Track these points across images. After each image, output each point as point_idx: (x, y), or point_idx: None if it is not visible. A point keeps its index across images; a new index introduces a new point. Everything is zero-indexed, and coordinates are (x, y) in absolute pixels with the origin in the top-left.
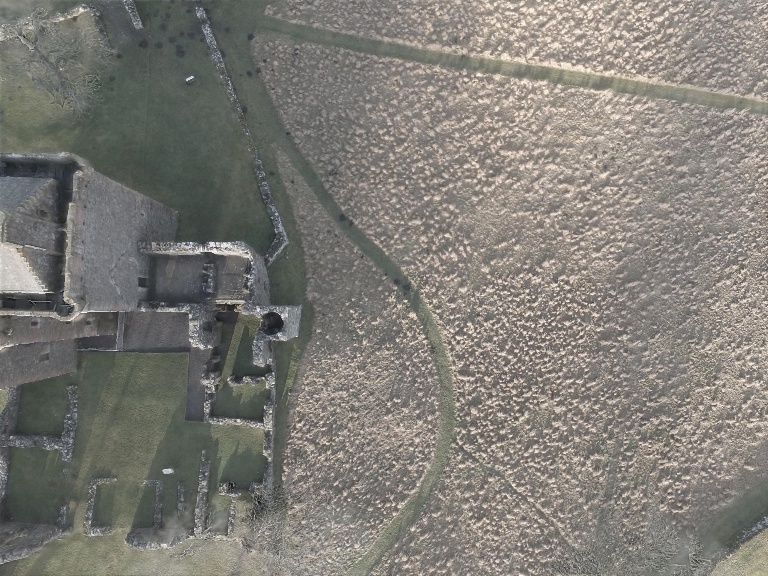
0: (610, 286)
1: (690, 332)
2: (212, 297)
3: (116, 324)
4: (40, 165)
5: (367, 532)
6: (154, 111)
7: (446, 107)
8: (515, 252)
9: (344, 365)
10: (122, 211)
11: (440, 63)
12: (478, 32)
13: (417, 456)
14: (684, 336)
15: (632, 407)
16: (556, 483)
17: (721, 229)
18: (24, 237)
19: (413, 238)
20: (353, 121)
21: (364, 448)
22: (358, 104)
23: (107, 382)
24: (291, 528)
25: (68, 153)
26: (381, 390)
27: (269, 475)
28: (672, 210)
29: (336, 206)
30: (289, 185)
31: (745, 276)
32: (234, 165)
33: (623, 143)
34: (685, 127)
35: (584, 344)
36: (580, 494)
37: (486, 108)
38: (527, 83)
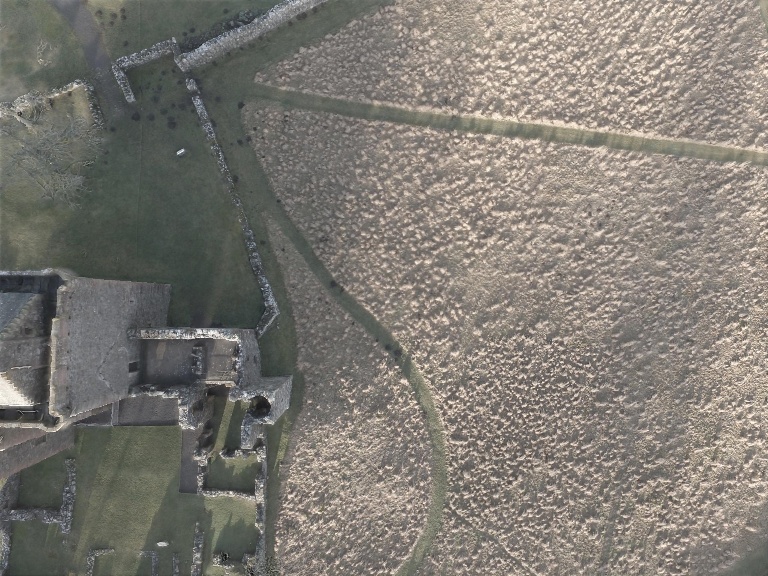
0: (605, 346)
1: (689, 392)
2: (201, 378)
3: None
4: (26, 278)
5: None
6: (147, 184)
7: (437, 169)
8: (508, 314)
9: (335, 434)
10: (110, 306)
11: (430, 125)
12: (468, 92)
13: (410, 522)
14: (682, 396)
15: (629, 469)
16: (551, 547)
17: (721, 285)
18: (7, 363)
19: (404, 303)
20: (343, 186)
21: (356, 515)
22: (348, 169)
23: (104, 455)
24: None
25: (51, 269)
26: (373, 457)
27: (261, 548)
28: (669, 267)
29: (327, 272)
30: (280, 253)
31: (746, 333)
32: (225, 236)
33: (618, 200)
34: (683, 182)
35: (579, 406)
36: (575, 558)
37: (477, 168)
38: (519, 142)
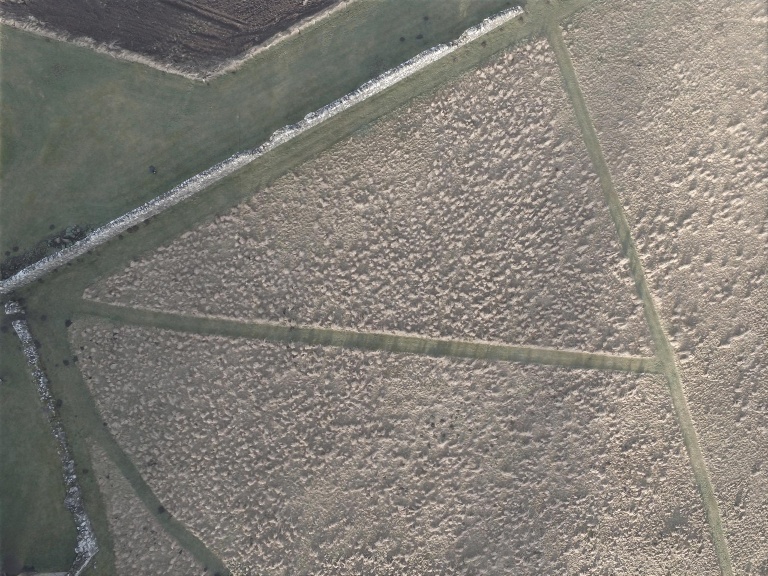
0: (448, 562)
1: None
2: None
3: None
4: None
5: None
6: None
7: (273, 383)
8: (346, 532)
9: None
10: None
11: (267, 338)
12: (307, 302)
13: None
14: None
15: None
16: None
17: (569, 494)
18: None
19: (236, 527)
20: (174, 406)
21: None
22: (179, 387)
23: None
24: None
25: None
26: None
27: None
28: (515, 477)
29: (155, 498)
30: (103, 482)
31: (595, 544)
32: (42, 470)
33: (462, 409)
34: (529, 389)
35: None
36: None
37: (316, 381)
38: (358, 354)
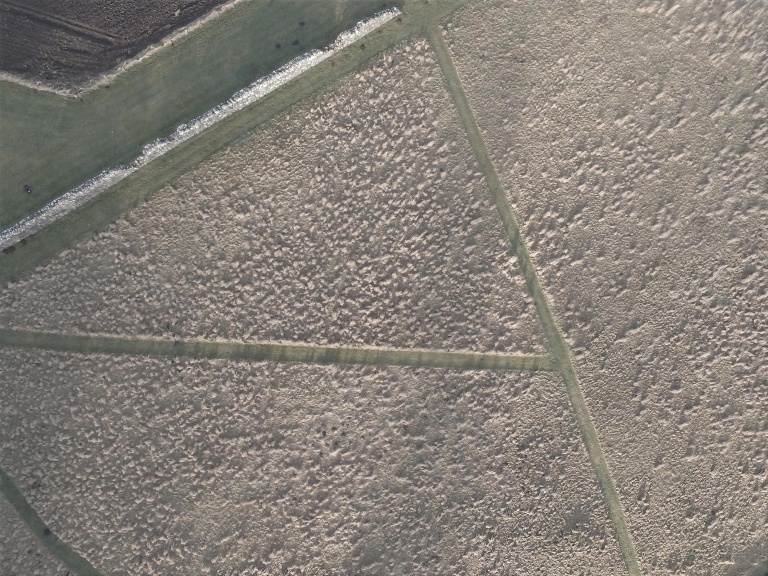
0: (345, 571)
1: None
2: None
3: None
4: None
5: None
6: None
7: (159, 399)
8: (239, 546)
9: None
10: None
11: (151, 353)
12: (191, 315)
13: None
14: None
15: None
16: None
17: (467, 496)
18: None
19: (124, 546)
20: (57, 427)
21: None
22: (62, 408)
23: None
24: None
25: None
26: None
27: None
28: (411, 482)
29: (40, 520)
30: None
31: (494, 545)
32: None
33: (354, 416)
34: (421, 392)
35: None
36: None
37: (203, 395)
38: (245, 365)
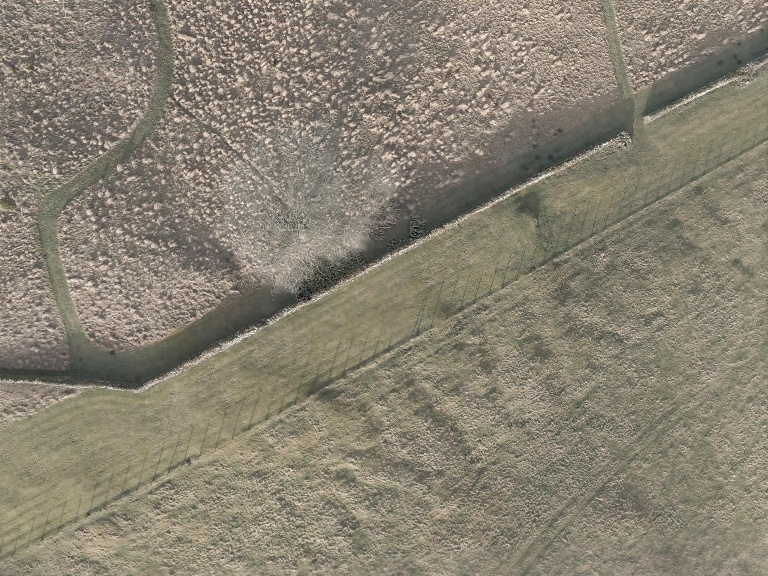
0: None
1: (422, 15)
2: None
3: None
4: None
5: (68, 163)
6: None
7: None
8: None
9: None
10: None
11: None
12: None
13: (129, 104)
14: (415, 18)
15: (357, 80)
16: (272, 143)
17: None
18: None
19: None
20: None
21: (71, 86)
22: None
23: None
24: None
25: None
26: (91, 33)
27: None
28: None
29: None
30: None
31: None
32: None
33: None
34: None
35: (311, 17)
36: (298, 158)
37: None
38: None
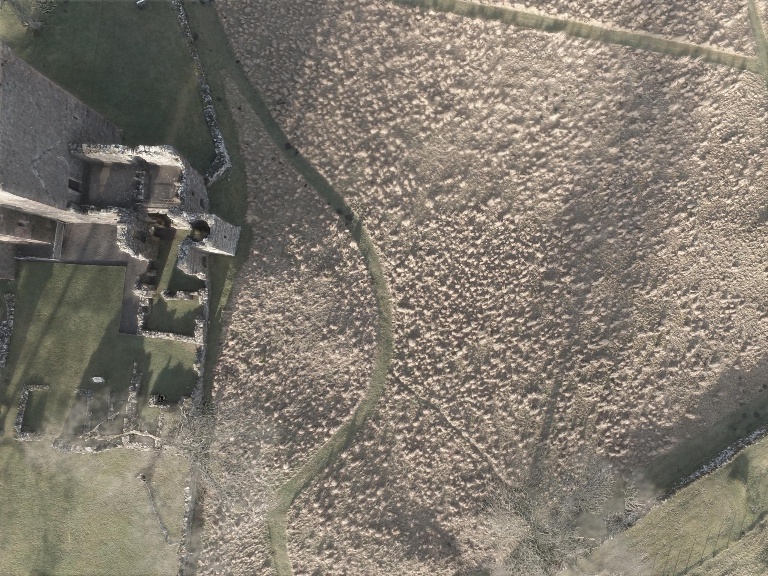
0: (555, 228)
1: (635, 277)
2: (144, 205)
3: (54, 233)
4: None
5: (297, 454)
6: (105, 33)
7: (397, 43)
8: (461, 189)
9: (280, 288)
10: (50, 106)
11: None
12: None
13: (352, 384)
14: (629, 281)
15: (572, 348)
16: (492, 419)
17: (671, 177)
18: None
19: (358, 170)
20: (303, 52)
21: (298, 372)
22: (309, 36)
23: (44, 291)
24: (219, 443)
25: None
26: (318, 316)
27: (198, 388)
28: (622, 155)
29: (282, 135)
30: (236, 111)
31: (693, 224)
32: (181, 88)
33: (574, 86)
34: (638, 73)
35: (526, 284)
36: (516, 432)
37: (437, 46)
38: (479, 23)
